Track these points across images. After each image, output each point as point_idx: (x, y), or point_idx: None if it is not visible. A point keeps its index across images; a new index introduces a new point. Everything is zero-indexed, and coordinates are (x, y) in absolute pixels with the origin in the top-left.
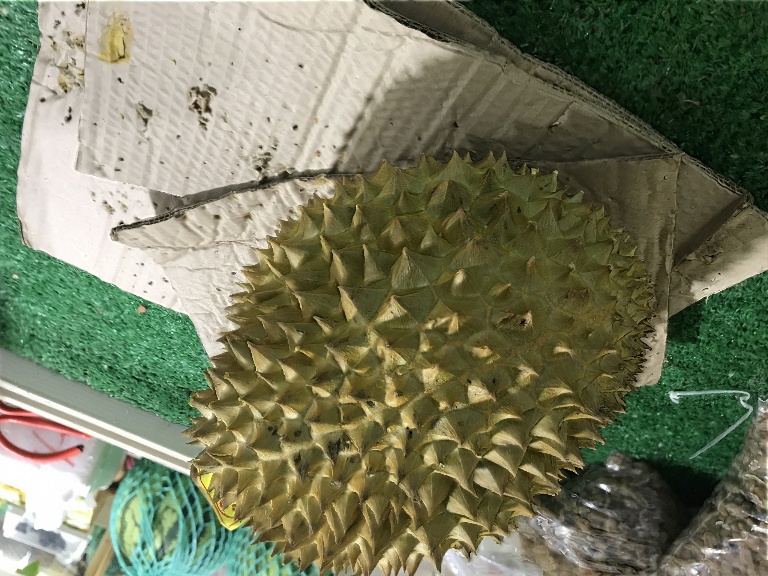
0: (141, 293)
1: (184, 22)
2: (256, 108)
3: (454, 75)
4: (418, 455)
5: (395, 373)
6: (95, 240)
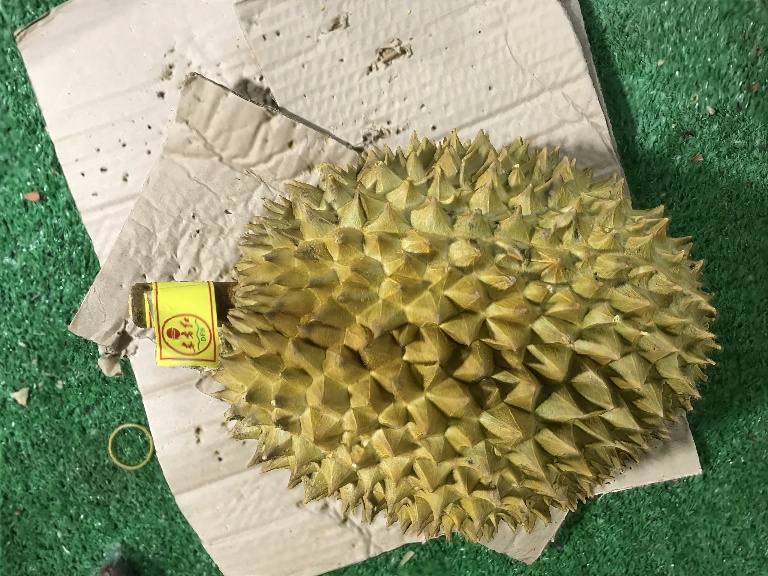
0: (73, 173)
1: None
2: (423, 91)
3: (593, 165)
4: (586, 307)
5: (602, 228)
6: (105, 88)
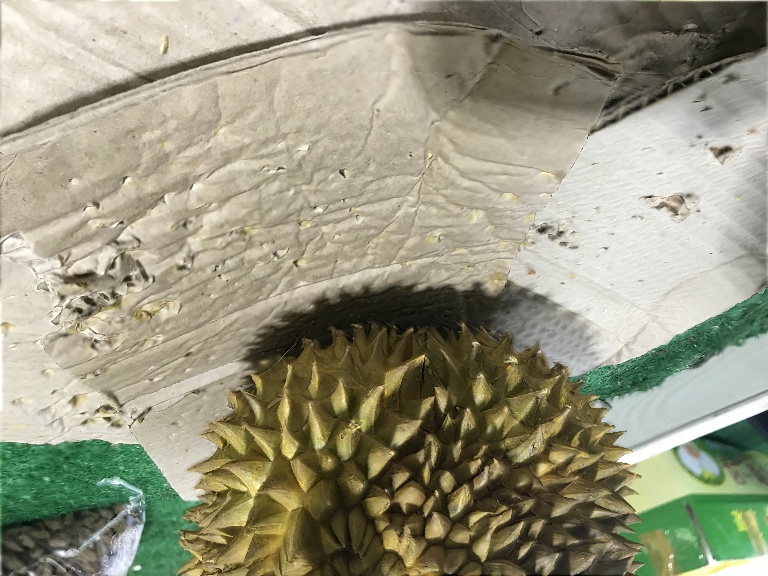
0: None
1: (760, 220)
2: (626, 242)
3: None
4: None
5: None
6: None
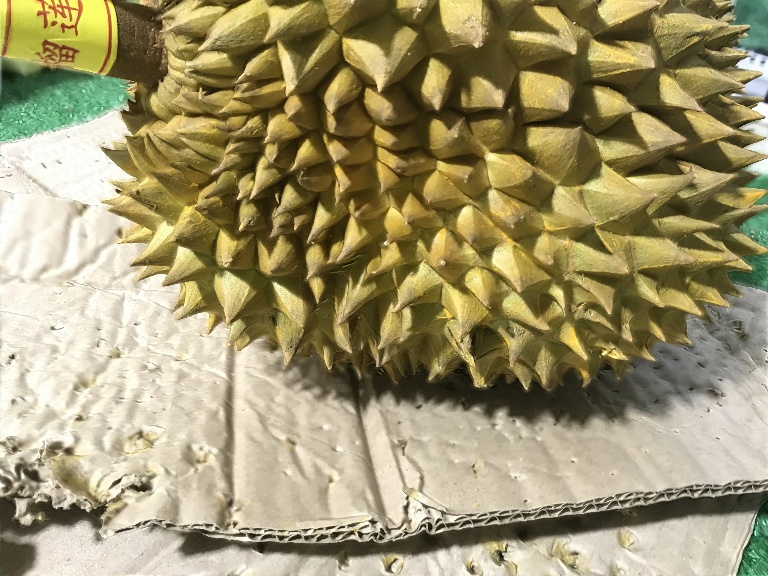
0: None
1: None
2: None
3: None
4: None
5: None
6: None
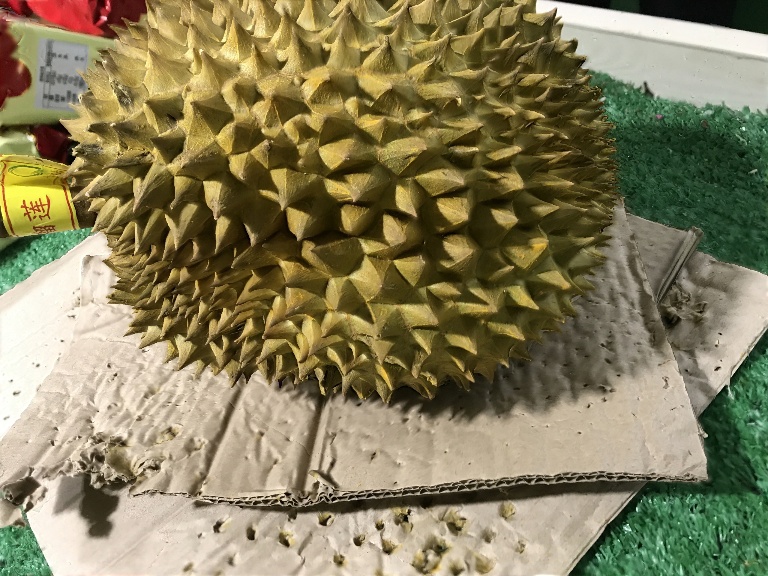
0: None
1: None
2: None
3: None
4: None
5: None
6: (20, 338)
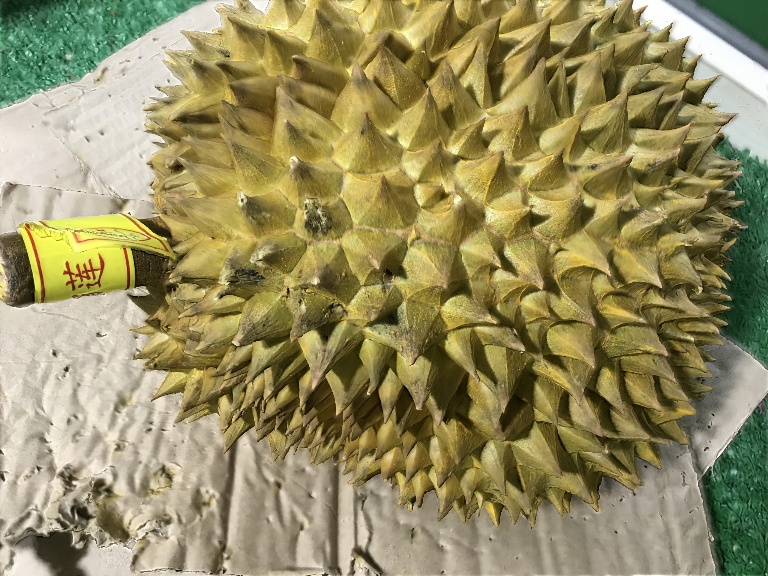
0: None
1: None
2: None
3: None
4: None
5: None
6: None
